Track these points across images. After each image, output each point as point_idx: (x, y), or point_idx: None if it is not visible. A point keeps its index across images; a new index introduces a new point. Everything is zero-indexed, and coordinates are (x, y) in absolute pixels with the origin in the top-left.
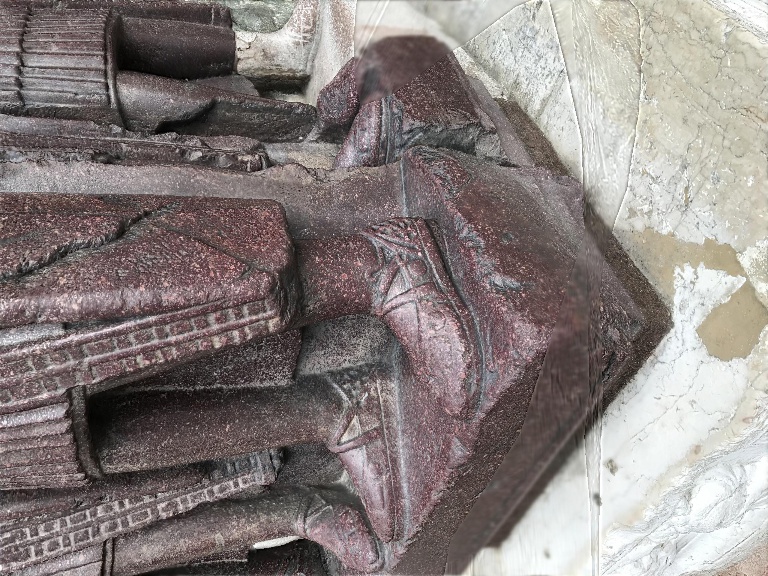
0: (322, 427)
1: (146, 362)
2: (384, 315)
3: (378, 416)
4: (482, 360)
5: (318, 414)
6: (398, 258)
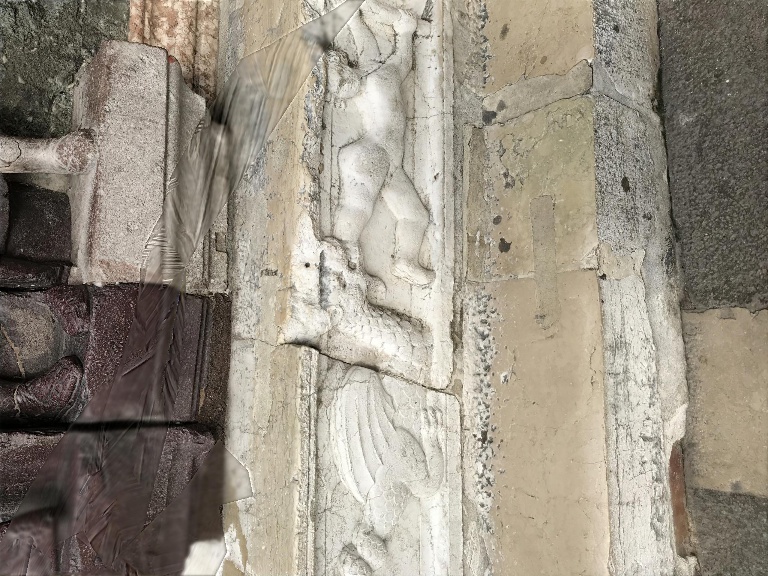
0: None
1: None
2: None
3: None
4: None
5: None
6: None
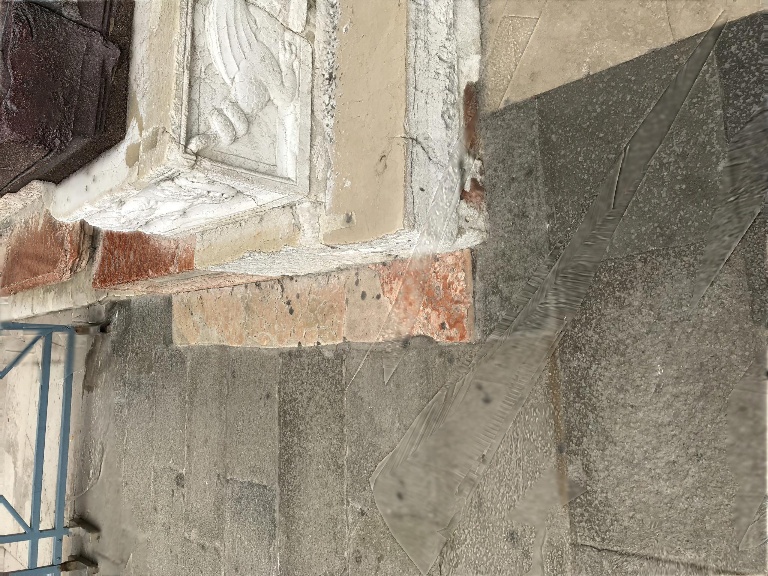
0: None
1: None
2: None
3: None
4: None
5: None
6: None
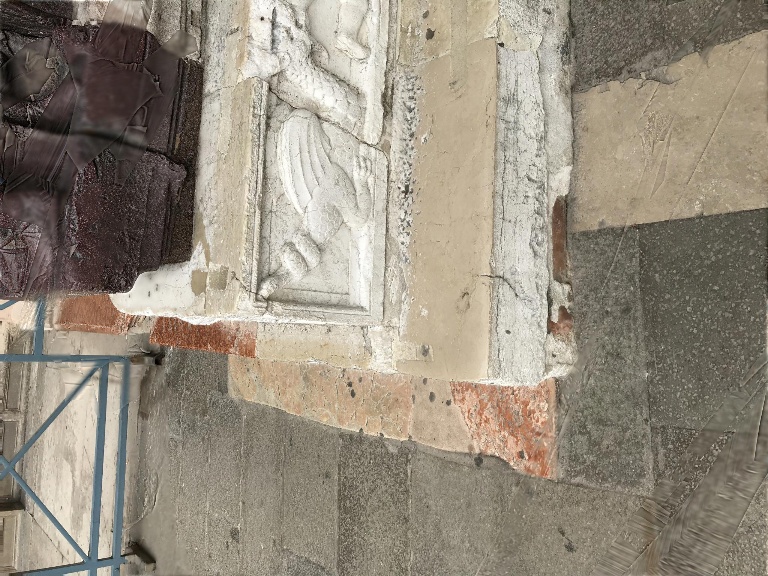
0: None
1: None
2: None
3: None
4: None
5: None
6: None
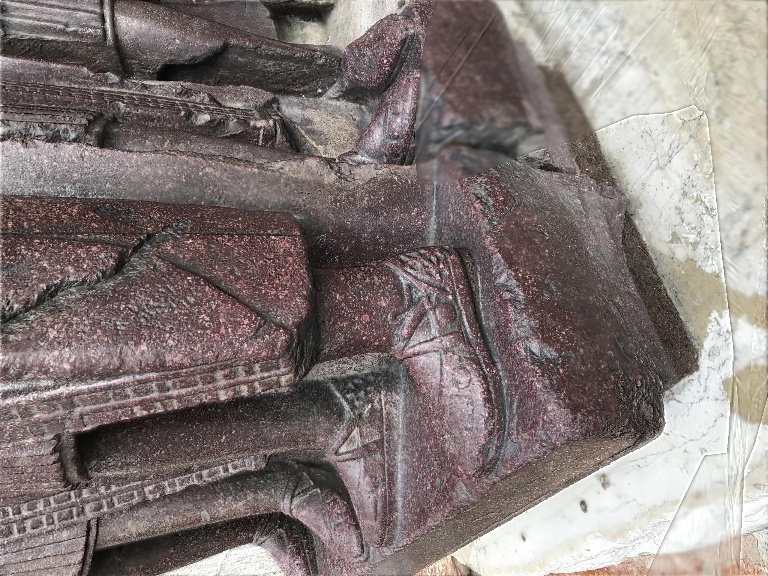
0: (321, 437)
1: (144, 412)
2: (404, 359)
3: (379, 429)
4: (505, 427)
5: (318, 425)
6: (426, 300)
